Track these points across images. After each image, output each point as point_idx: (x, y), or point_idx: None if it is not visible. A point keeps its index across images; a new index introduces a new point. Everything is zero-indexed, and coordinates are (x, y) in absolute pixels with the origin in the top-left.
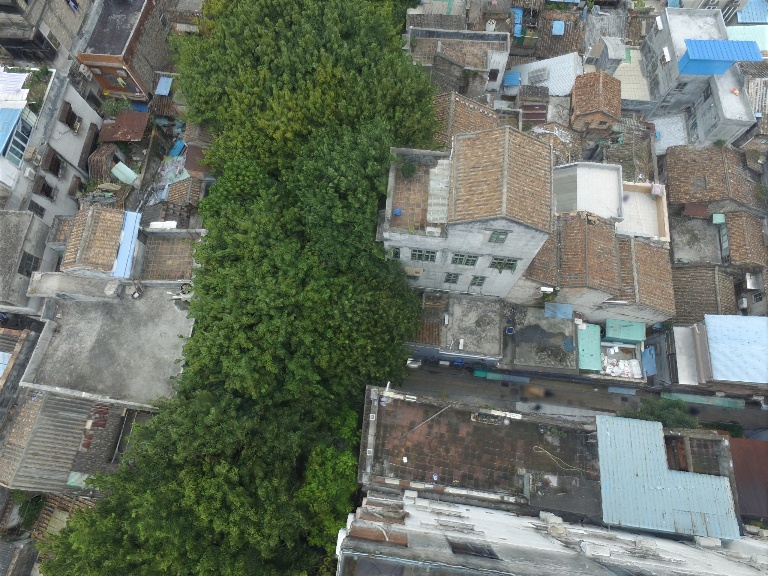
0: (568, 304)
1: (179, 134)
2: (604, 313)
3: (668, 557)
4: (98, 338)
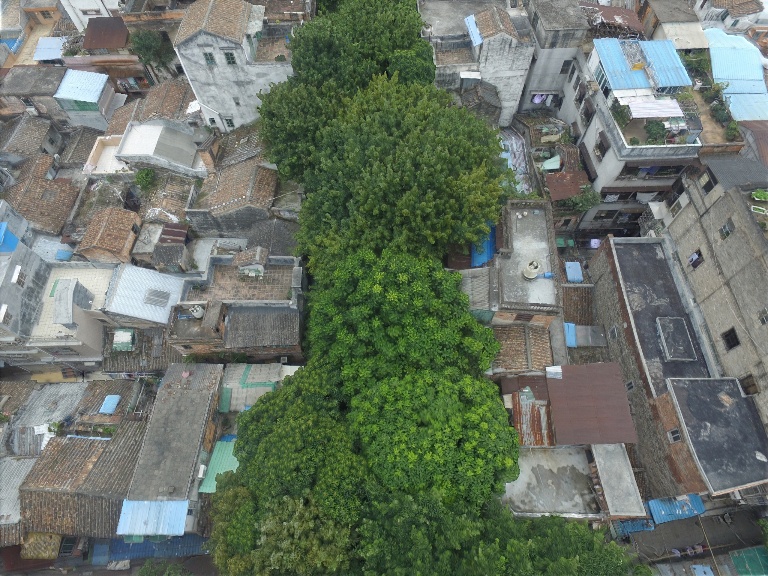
0: None
1: None
2: None
3: None
4: None
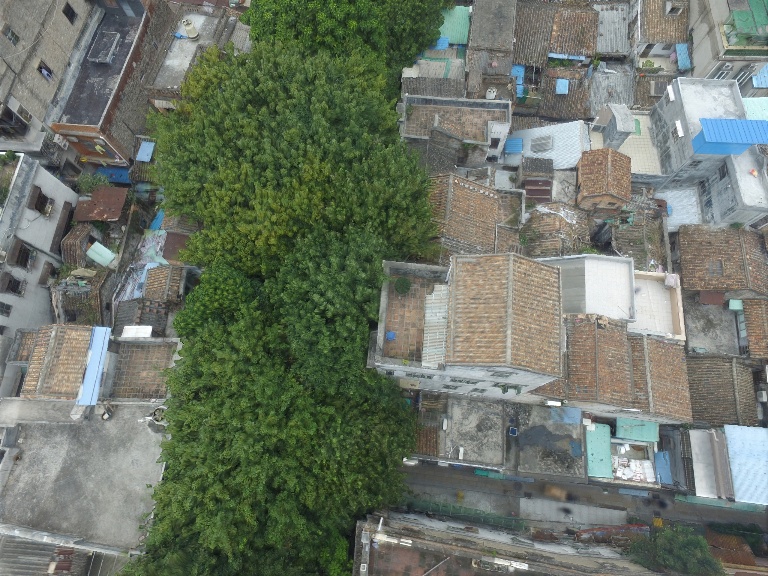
0: (576, 408)
1: (162, 200)
2: (615, 414)
3: None
4: (64, 466)
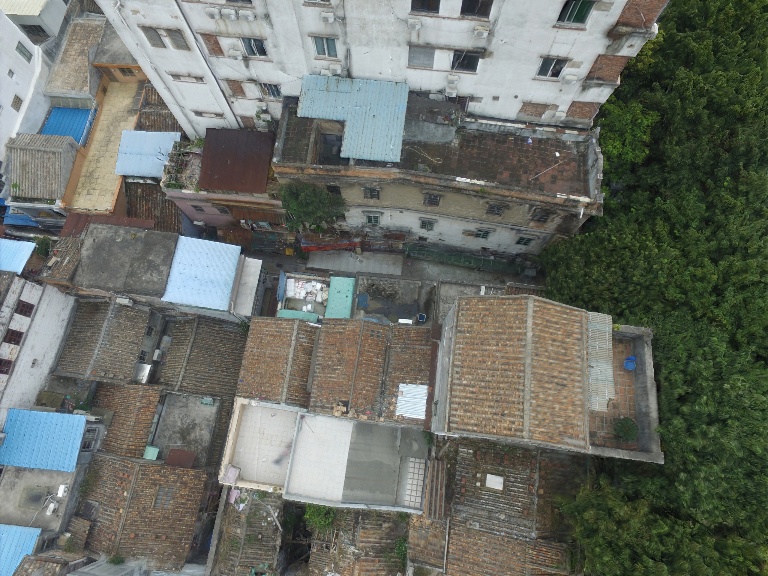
0: None
1: None
2: None
3: (410, 1)
4: None
